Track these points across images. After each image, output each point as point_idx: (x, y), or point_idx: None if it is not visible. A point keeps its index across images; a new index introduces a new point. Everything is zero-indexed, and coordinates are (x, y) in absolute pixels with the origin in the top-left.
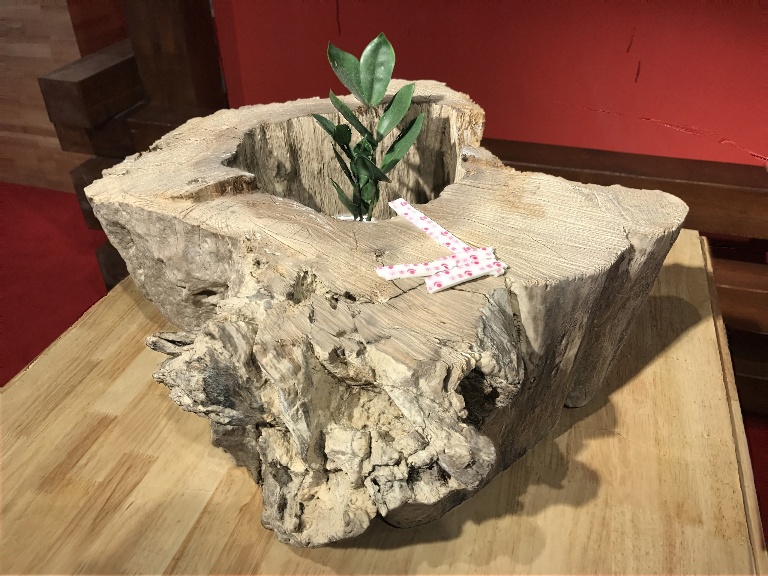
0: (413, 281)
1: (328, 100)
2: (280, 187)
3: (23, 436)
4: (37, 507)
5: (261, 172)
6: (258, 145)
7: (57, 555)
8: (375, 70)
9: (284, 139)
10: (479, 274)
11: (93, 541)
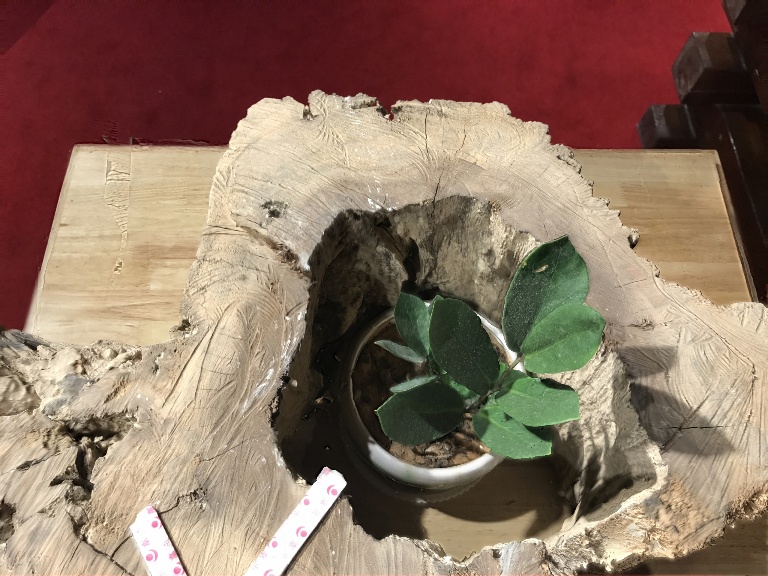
0: (136, 563)
1: (626, 257)
2: (483, 266)
3: (186, 200)
4: None
5: (468, 236)
6: (475, 215)
7: (77, 299)
8: (565, 338)
9: (503, 241)
10: None
11: (93, 318)
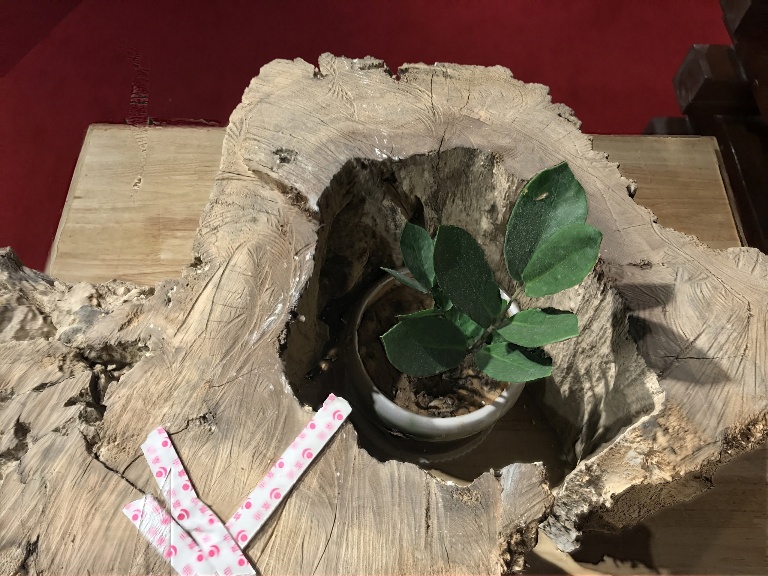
0: (146, 480)
1: (624, 204)
2: (486, 224)
3: (197, 176)
4: (128, 228)
5: (471, 193)
6: (479, 168)
7: (89, 267)
8: (564, 260)
9: (506, 192)
10: (174, 567)
11: None
